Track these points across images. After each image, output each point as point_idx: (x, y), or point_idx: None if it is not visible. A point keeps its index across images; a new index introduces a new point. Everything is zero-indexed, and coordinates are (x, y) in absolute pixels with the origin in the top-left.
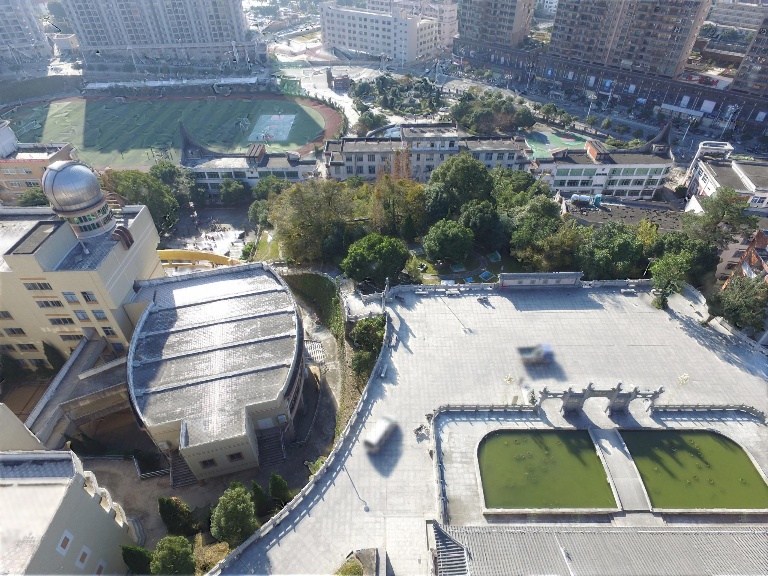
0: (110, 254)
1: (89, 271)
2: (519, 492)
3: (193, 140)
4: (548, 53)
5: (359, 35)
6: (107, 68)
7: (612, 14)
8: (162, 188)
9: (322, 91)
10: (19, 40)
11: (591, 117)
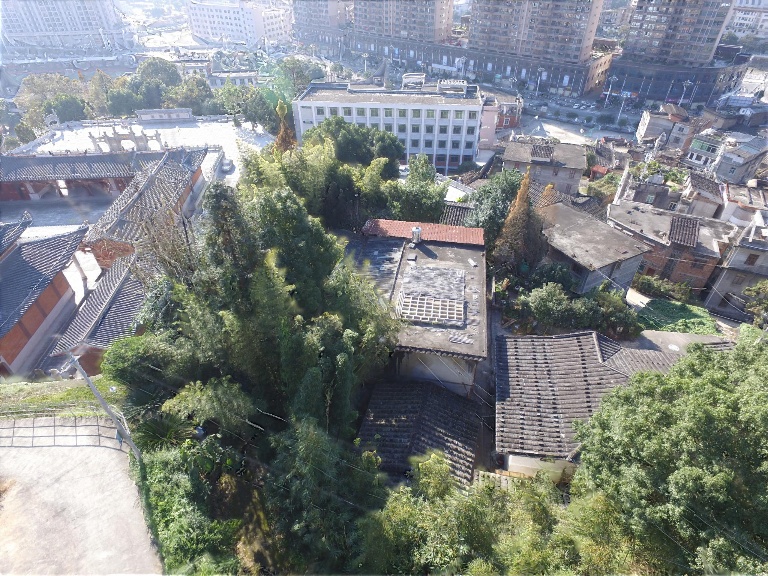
0: None
1: None
2: None
3: (11, 81)
4: (355, 30)
5: (218, 25)
6: None
7: None
8: None
9: None
10: None
11: (366, 72)
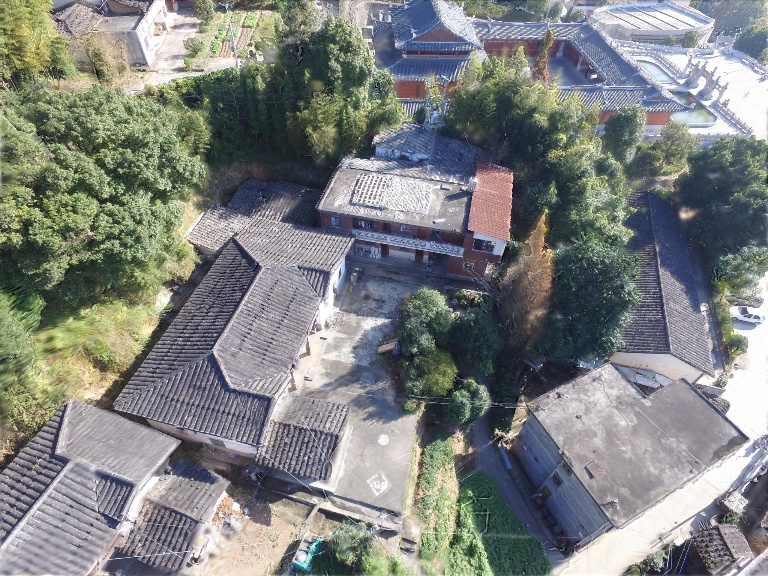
0: None
1: None
2: None
3: None
4: None
5: None
6: None
7: None
8: None
9: None
10: None
11: None
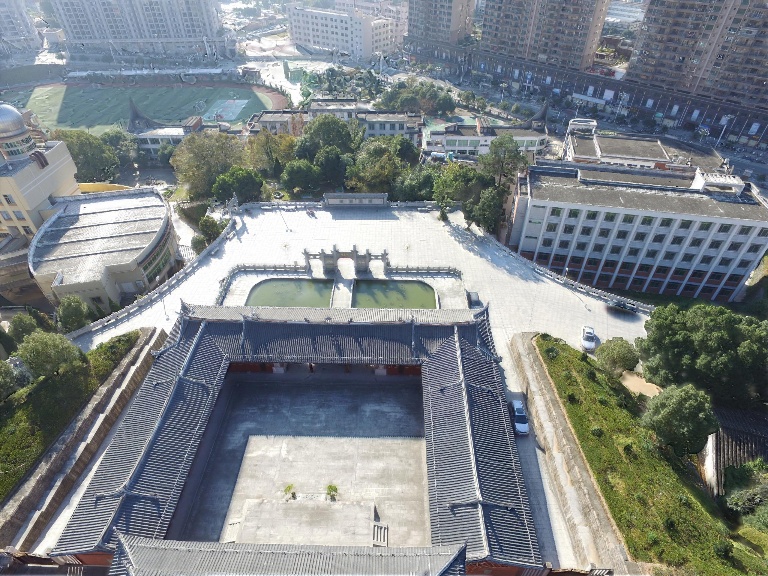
0: (26, 168)
1: (7, 177)
2: None
3: (140, 112)
4: (480, 49)
5: (321, 33)
6: (88, 58)
7: (528, 13)
8: (105, 147)
9: (278, 81)
10: (11, 33)
11: (503, 103)
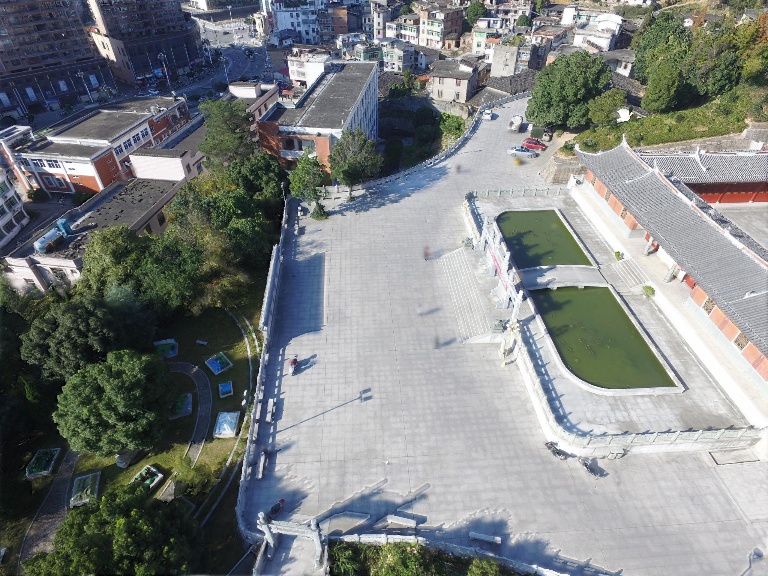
0: None
1: None
2: (635, 356)
3: None
4: None
5: None
6: None
7: None
8: None
9: None
10: None
11: None
